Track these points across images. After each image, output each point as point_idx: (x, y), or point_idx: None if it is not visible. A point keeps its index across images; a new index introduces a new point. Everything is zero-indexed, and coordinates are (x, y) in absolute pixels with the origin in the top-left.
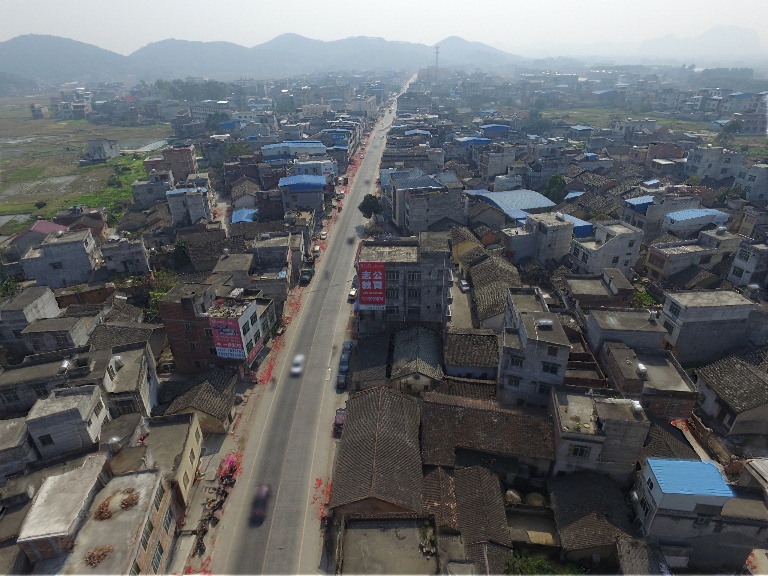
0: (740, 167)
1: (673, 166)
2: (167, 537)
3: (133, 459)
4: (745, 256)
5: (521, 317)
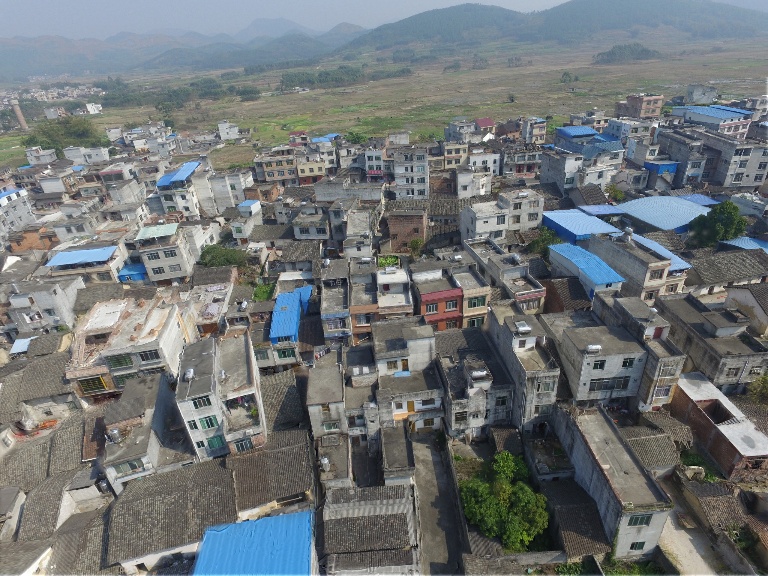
0: None
1: None
2: (288, 175)
3: (300, 156)
4: None
5: None
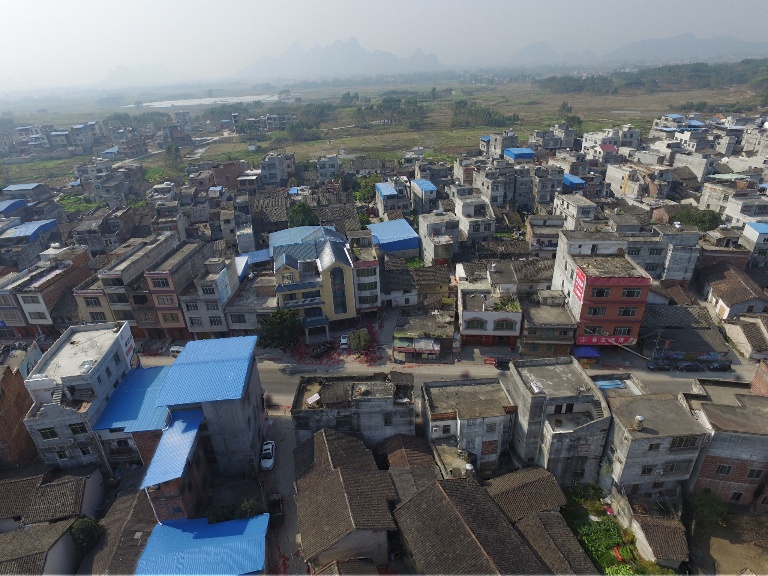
0: (318, 161)
1: (258, 179)
2: None
3: None
4: (496, 188)
5: (672, 234)
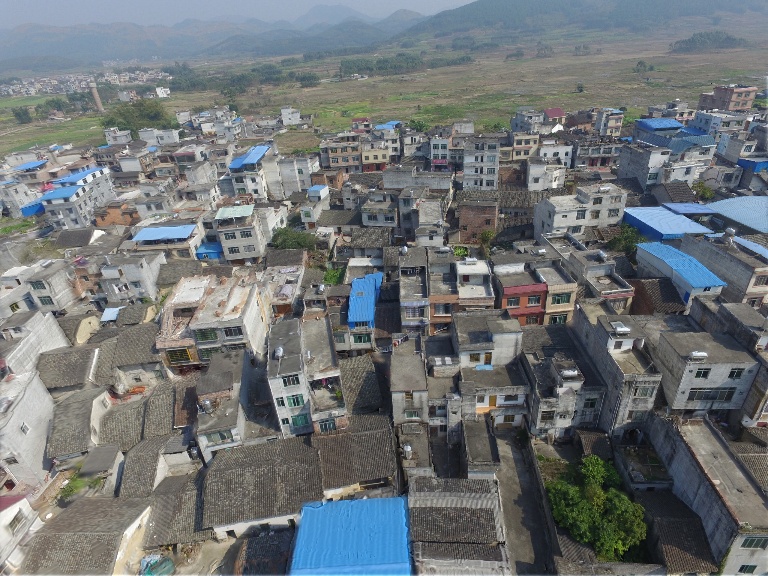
0: None
1: None
2: (352, 162)
3: None
4: None
5: None
